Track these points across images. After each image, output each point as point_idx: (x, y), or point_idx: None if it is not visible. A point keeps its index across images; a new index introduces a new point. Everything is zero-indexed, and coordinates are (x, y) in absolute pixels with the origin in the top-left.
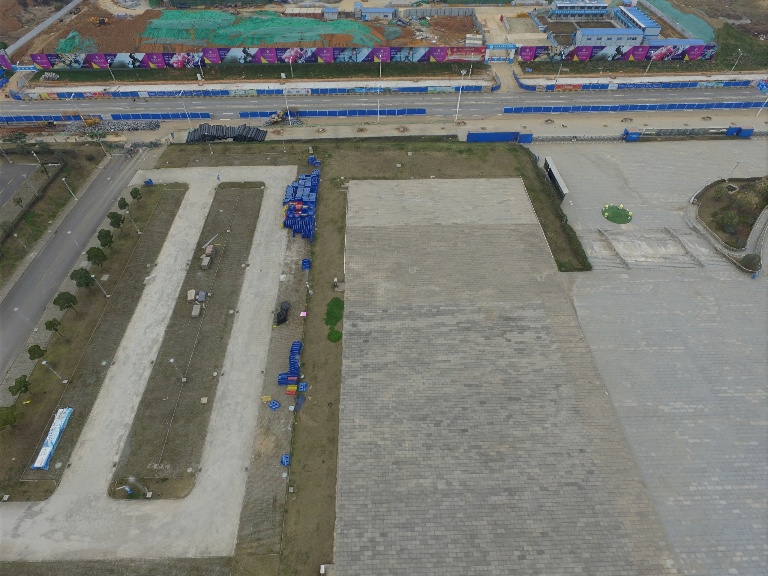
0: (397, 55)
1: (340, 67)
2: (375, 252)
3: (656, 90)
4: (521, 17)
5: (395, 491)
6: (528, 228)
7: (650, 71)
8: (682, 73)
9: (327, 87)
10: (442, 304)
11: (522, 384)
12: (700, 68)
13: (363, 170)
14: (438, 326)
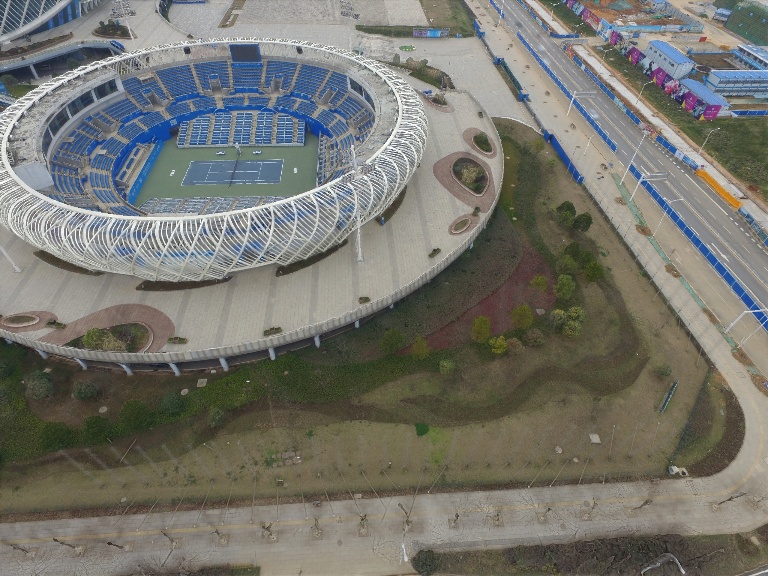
0: (574, 6)
1: (556, 1)
2: (367, 0)
3: (597, 87)
4: (722, 49)
5: (269, 0)
6: (385, 22)
7: (640, 90)
8: (648, 103)
9: (529, 2)
10: (337, 7)
11: (300, 14)
12: (670, 113)
13: (428, 0)
14: (327, 6)
